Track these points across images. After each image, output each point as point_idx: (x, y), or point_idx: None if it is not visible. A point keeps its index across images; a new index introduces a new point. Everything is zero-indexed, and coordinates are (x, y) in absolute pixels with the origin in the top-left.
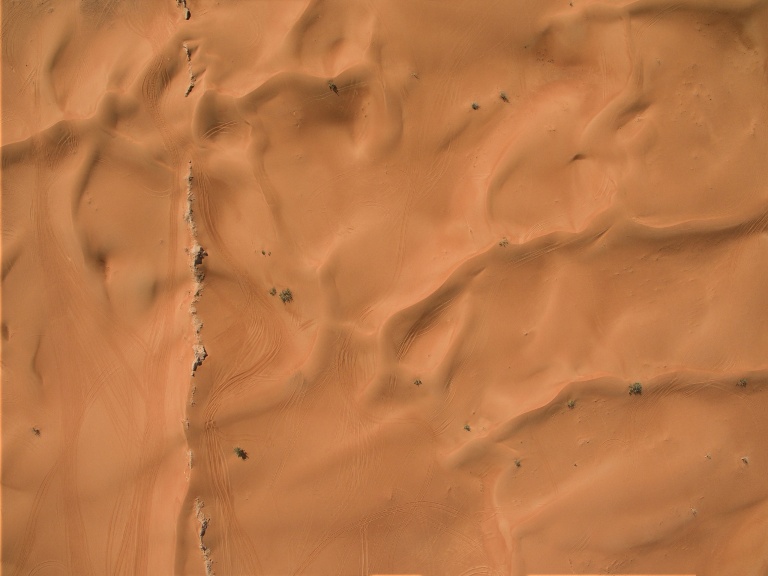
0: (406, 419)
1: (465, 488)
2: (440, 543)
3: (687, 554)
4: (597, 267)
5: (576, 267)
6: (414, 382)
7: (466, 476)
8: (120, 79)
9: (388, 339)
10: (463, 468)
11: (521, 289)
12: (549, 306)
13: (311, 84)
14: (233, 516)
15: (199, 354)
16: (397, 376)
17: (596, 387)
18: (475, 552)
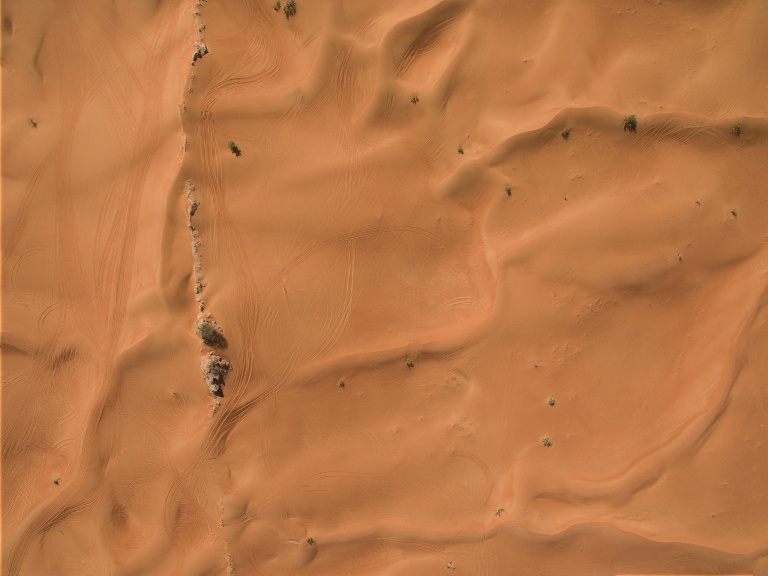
0: (401, 142)
1: (455, 220)
2: (426, 272)
3: (671, 306)
4: (600, 2)
5: (579, 0)
6: (411, 100)
7: (456, 206)
8: None
9: (388, 52)
10: (454, 197)
11: (523, 16)
12: (550, 37)
13: None
14: (223, 207)
15: (200, 48)
16: (395, 93)
17: (591, 117)
18: (460, 284)
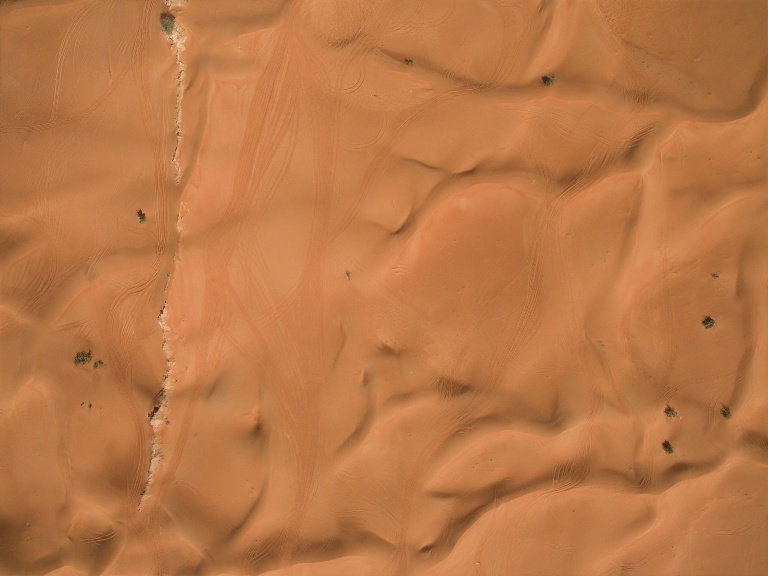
0: None
1: None
2: None
3: None
4: None
5: None
6: None
7: None
8: None
9: None
10: None
11: None
12: None
13: (2, 565)
14: (157, 159)
15: None
16: None
17: None
18: None
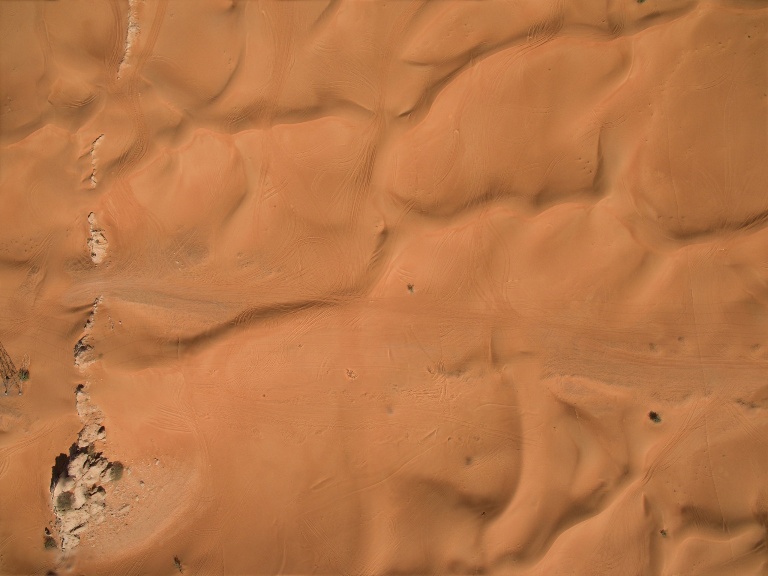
0: None
1: None
2: None
3: None
4: None
5: None
6: None
7: None
8: (170, 166)
9: None
10: None
11: None
12: None
13: None
14: None
15: None
16: None
17: None
18: None
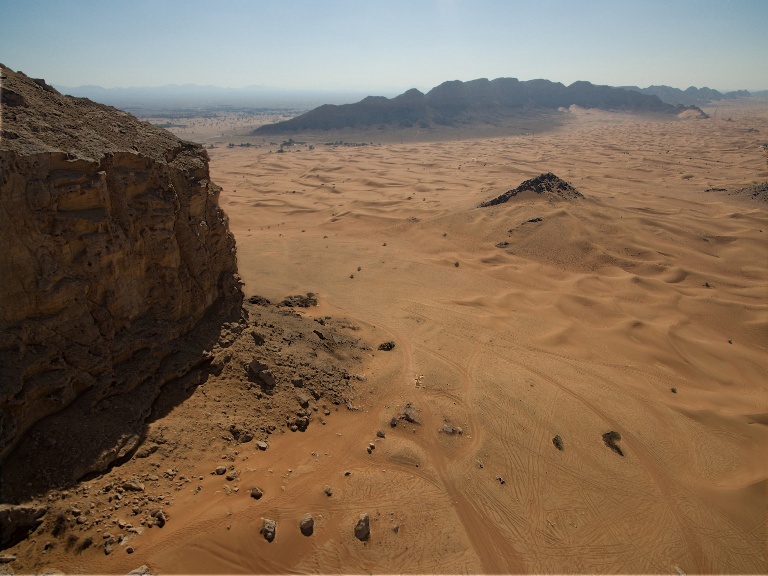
0: None
1: None
2: None
3: None
4: None
5: None
6: None
7: None
8: None
9: None
10: None
11: None
12: None
13: None
14: None
15: None
16: None
17: None
18: None
